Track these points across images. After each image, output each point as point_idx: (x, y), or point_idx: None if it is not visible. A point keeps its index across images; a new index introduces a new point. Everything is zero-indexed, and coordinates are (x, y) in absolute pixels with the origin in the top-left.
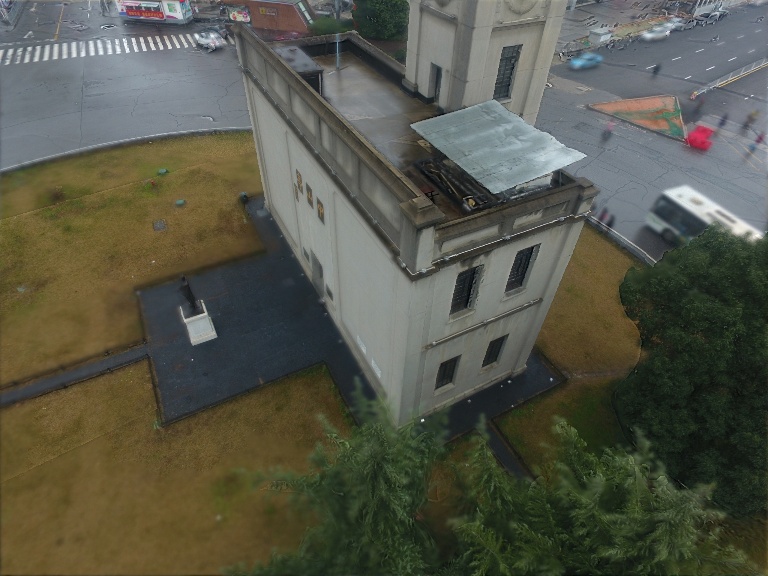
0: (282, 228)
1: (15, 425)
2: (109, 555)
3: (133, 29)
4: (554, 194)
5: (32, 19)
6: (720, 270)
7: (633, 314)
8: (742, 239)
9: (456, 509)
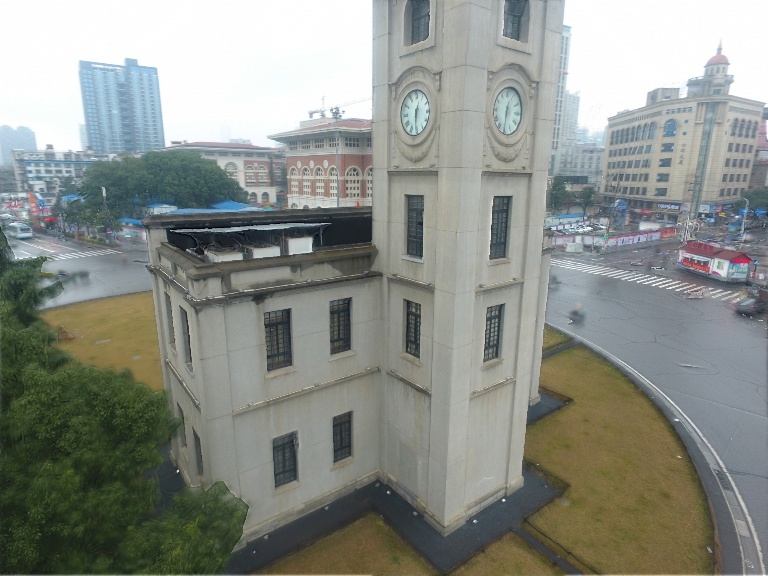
0: None
1: None
2: (141, 371)
3: (673, 274)
4: (191, 261)
5: None
6: None
7: None
8: None
9: None
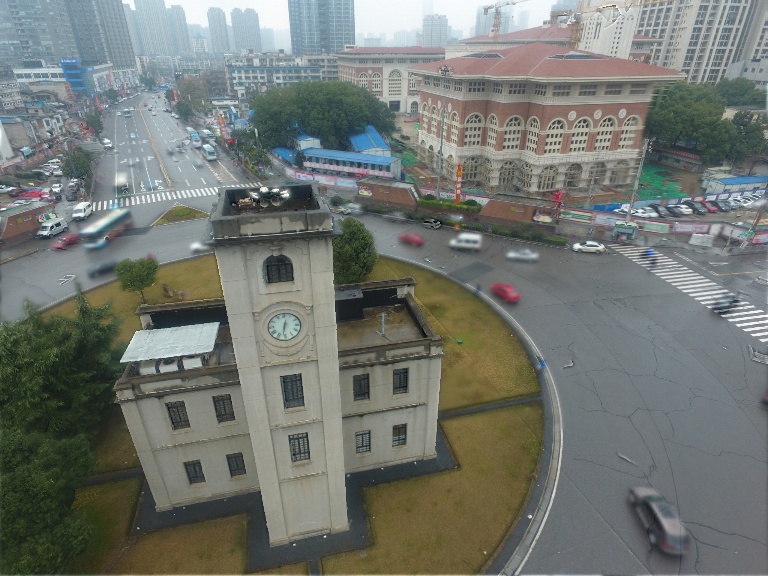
0: None
1: None
2: None
3: None
4: None
5: (762, 259)
6: None
7: None
8: None
9: (93, 383)
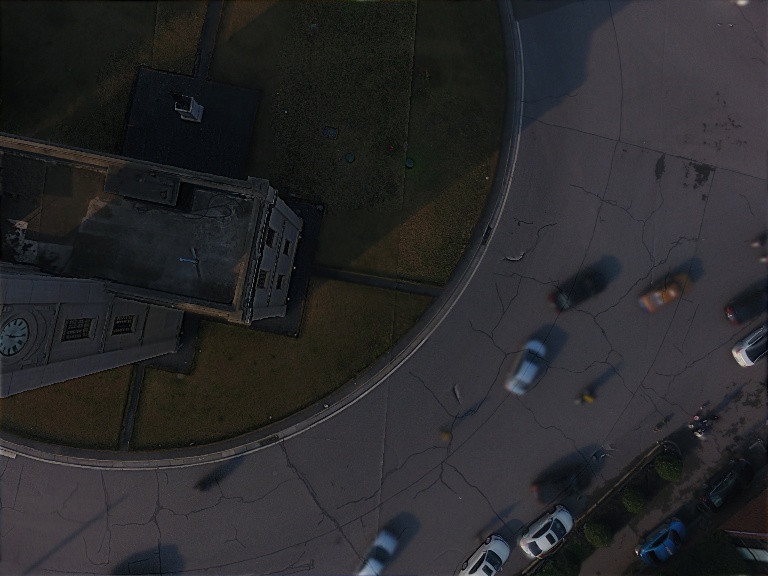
0: None
1: (193, 3)
2: (87, 23)
3: None
4: None
5: None
6: None
7: None
8: None
9: None
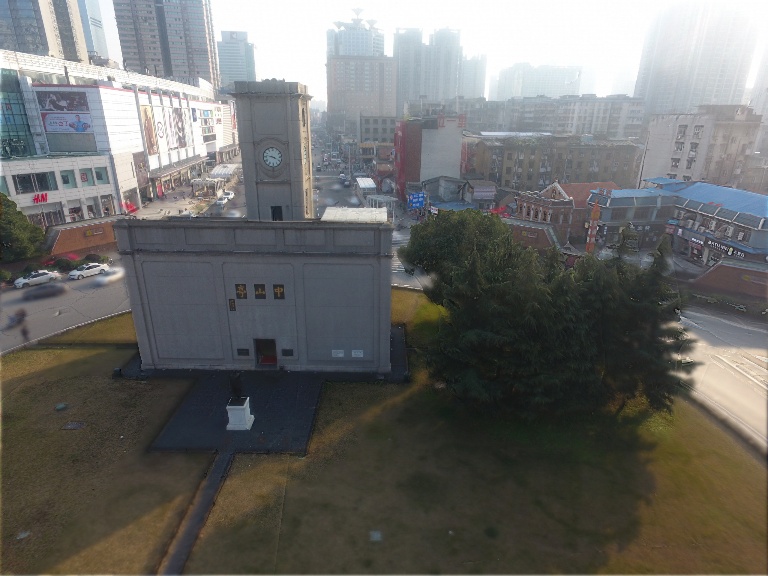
0: (187, 364)
1: (223, 539)
2: (381, 486)
3: None
4: None
5: None
6: (434, 229)
7: (422, 261)
8: (426, 223)
9: None
